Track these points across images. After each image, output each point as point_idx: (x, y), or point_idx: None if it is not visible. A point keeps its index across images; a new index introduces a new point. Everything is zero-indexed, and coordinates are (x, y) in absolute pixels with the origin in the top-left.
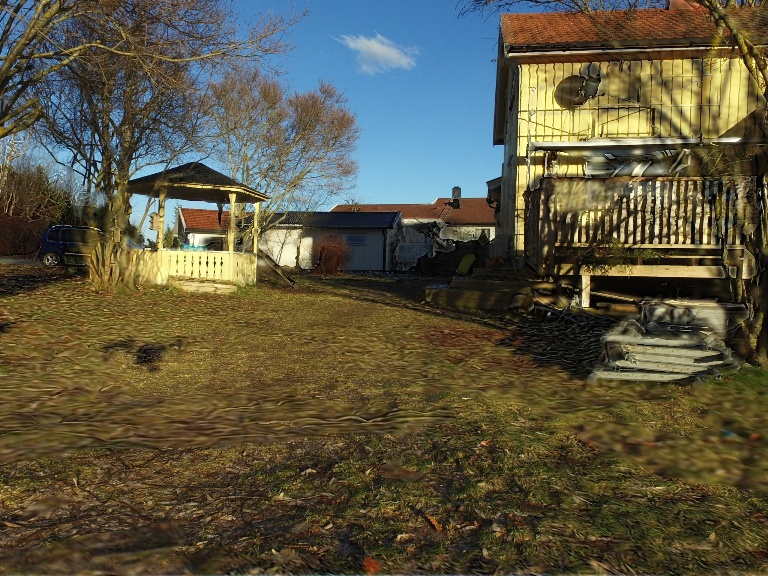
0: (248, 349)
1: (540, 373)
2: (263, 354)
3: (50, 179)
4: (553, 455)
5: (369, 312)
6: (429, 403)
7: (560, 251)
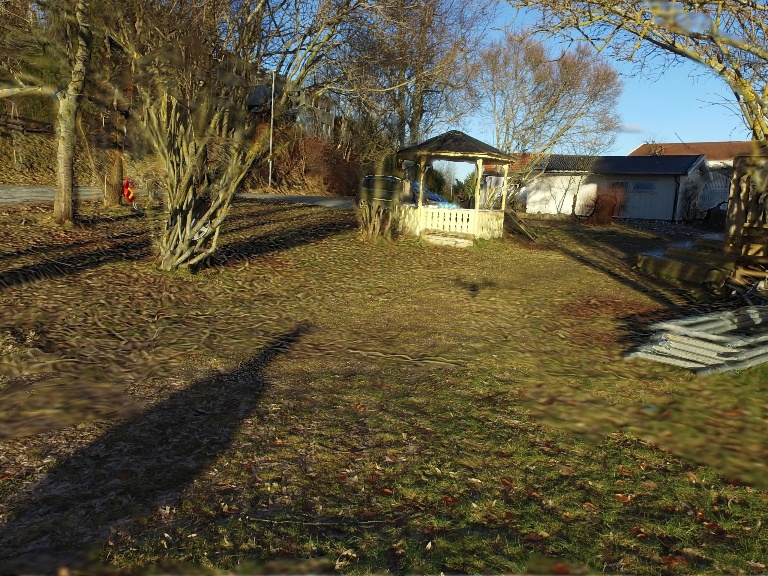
0: (410, 302)
1: (603, 347)
2: (416, 307)
3: (378, 128)
4: (483, 394)
5: (562, 275)
6: (463, 355)
7: (749, 231)
